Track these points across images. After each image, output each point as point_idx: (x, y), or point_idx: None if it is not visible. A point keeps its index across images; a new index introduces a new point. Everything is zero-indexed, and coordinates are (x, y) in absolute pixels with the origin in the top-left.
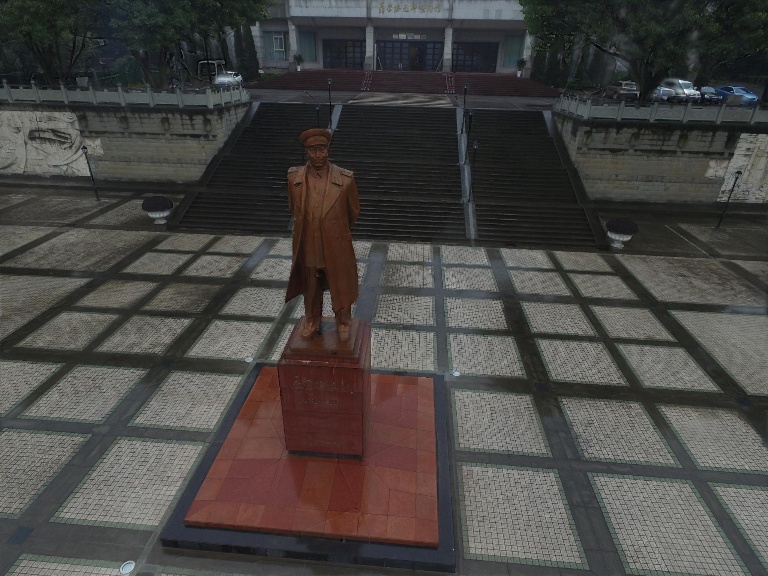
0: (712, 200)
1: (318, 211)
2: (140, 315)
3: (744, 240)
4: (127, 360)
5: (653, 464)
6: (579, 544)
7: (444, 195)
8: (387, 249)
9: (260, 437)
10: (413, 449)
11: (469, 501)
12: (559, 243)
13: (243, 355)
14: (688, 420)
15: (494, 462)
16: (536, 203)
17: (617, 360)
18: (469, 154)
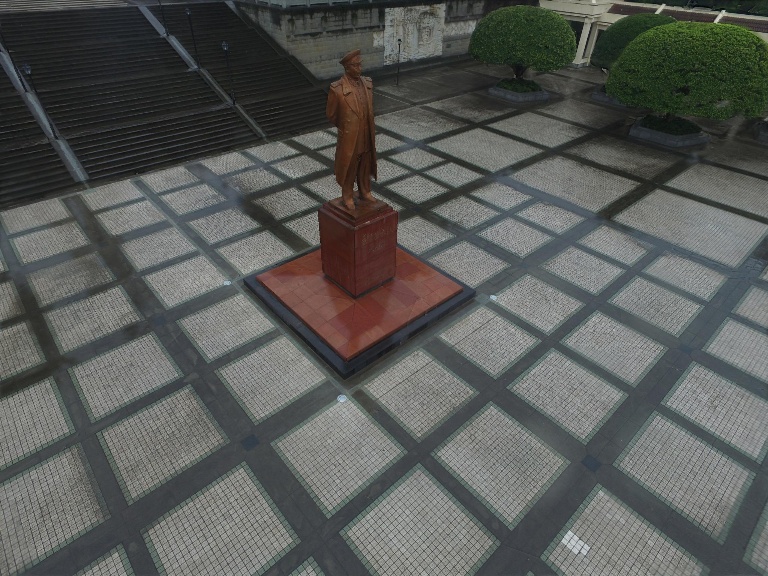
0: (381, 65)
1: (365, 110)
2: (52, 310)
3: (417, 90)
4: (116, 339)
5: (492, 218)
6: (500, 260)
7: (205, 104)
8: (205, 167)
9: (325, 304)
10: (407, 263)
11: (448, 271)
12: (326, 122)
13: (217, 283)
14: (485, 194)
15: (439, 251)
16: (286, 93)
17: (433, 180)
18: (193, 57)
